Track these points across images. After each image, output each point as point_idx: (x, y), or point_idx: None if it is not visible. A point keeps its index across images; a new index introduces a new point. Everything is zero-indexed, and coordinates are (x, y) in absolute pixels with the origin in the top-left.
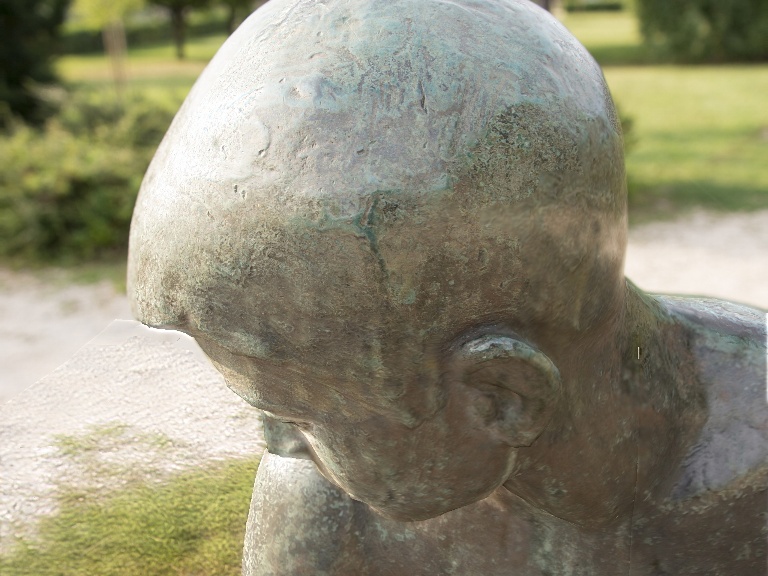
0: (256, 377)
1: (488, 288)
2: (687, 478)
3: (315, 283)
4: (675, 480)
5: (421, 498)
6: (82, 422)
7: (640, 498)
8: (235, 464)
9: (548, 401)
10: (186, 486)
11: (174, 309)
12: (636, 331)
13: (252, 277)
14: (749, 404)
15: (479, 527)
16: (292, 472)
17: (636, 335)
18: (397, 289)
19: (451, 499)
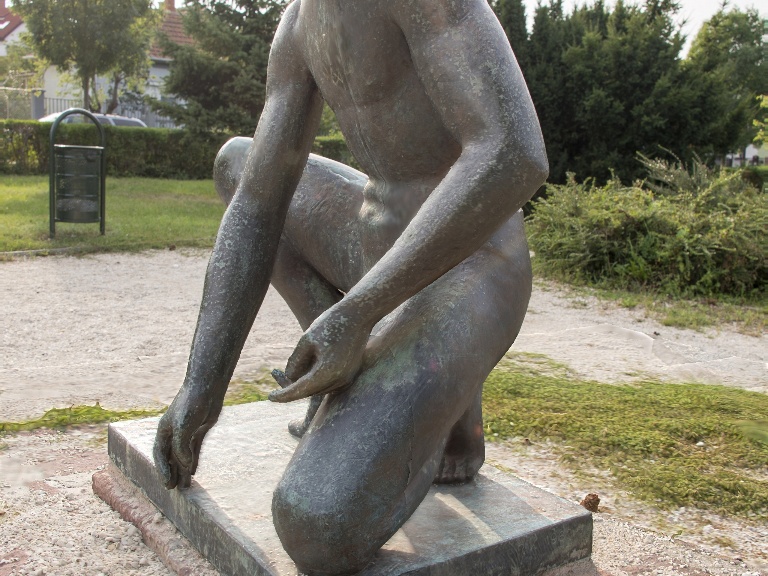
0: None
1: None
2: None
3: None
4: None
5: None
6: (523, 351)
7: None
8: (592, 383)
9: None
10: None
11: None
12: None
13: None
14: None
15: (308, 4)
16: None
17: None
18: None
19: None
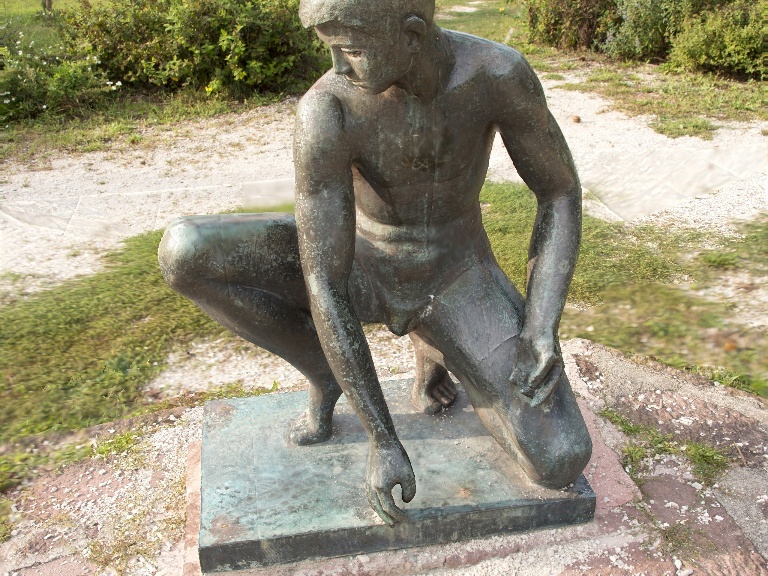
0: (350, 36)
1: (412, 3)
2: (452, 81)
3: (375, 2)
4: (448, 82)
5: (389, 74)
6: None
7: (440, 86)
8: (95, 279)
9: (424, 35)
10: (63, 297)
11: (331, 16)
12: (436, 30)
13: (358, 3)
14: (467, 57)
15: (388, 110)
16: (317, 105)
17: (436, 31)
18: (394, 2)
19: (396, 74)
